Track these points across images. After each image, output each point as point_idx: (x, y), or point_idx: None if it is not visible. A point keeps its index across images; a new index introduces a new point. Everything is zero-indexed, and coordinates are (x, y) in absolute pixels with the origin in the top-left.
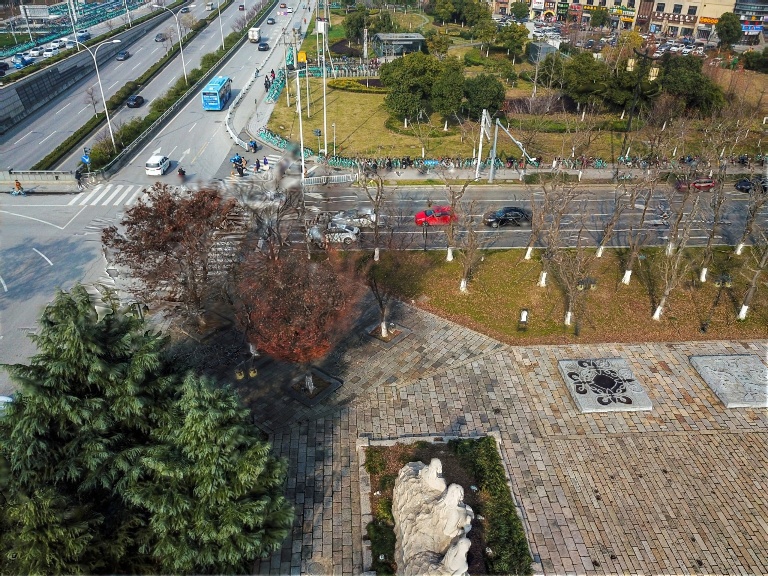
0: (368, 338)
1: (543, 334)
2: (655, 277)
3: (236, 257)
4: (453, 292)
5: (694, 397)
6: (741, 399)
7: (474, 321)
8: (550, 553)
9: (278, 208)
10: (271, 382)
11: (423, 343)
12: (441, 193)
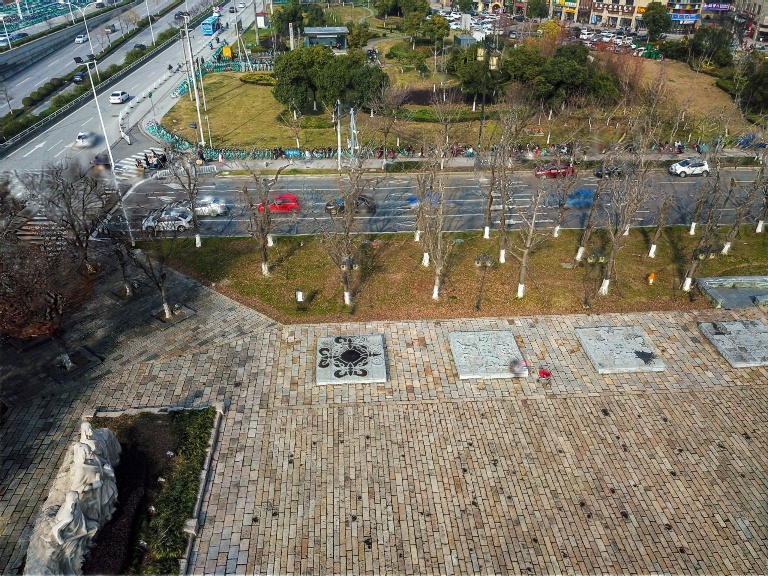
0: (150, 319)
1: (320, 313)
2: (458, 259)
3: (66, 245)
4: (255, 275)
5: (434, 370)
6: (473, 371)
7: (261, 302)
8: (218, 511)
9: (83, 196)
10: (37, 361)
11: (201, 323)
12: (300, 182)
